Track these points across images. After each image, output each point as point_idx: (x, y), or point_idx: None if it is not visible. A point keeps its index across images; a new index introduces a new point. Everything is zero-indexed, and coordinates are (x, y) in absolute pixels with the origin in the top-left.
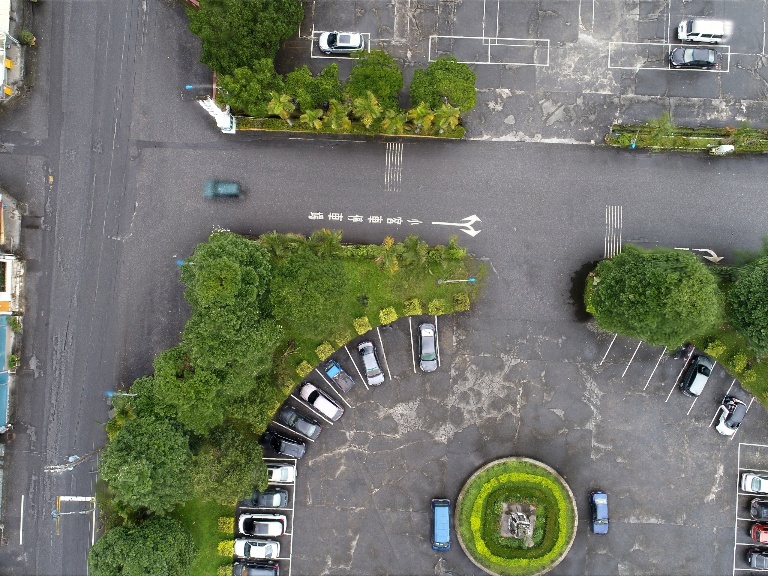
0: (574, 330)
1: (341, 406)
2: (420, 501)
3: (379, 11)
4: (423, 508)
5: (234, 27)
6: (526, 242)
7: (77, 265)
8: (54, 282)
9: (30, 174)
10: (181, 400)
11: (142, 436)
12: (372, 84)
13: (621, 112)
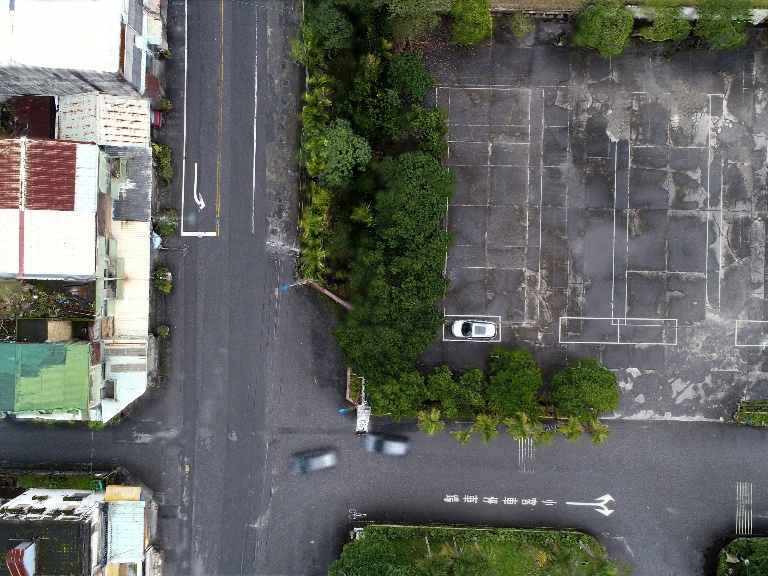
0: None
1: None
2: None
3: (509, 294)
4: None
5: (384, 347)
6: (659, 520)
7: (215, 553)
8: (192, 571)
9: (166, 464)
10: None
11: None
12: (515, 388)
13: (749, 389)
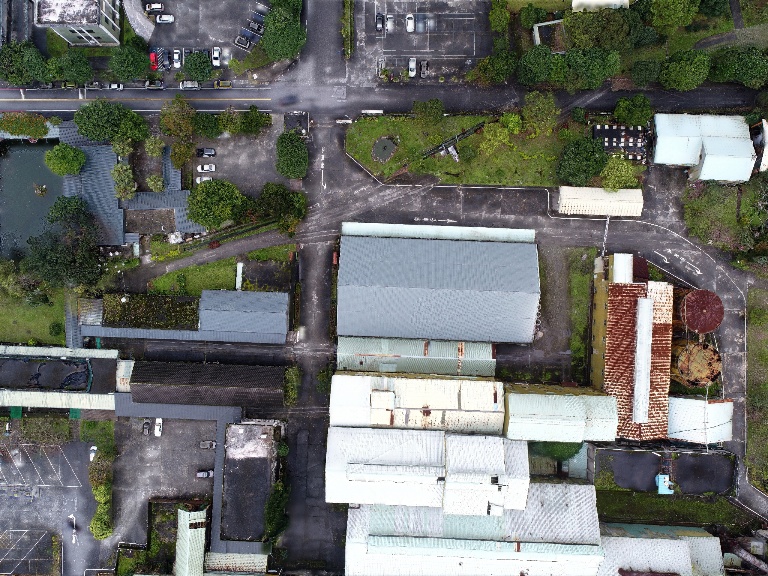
0: None
1: None
2: None
3: None
4: None
5: None
6: None
7: None
8: None
9: None
10: None
11: None
12: None
13: None
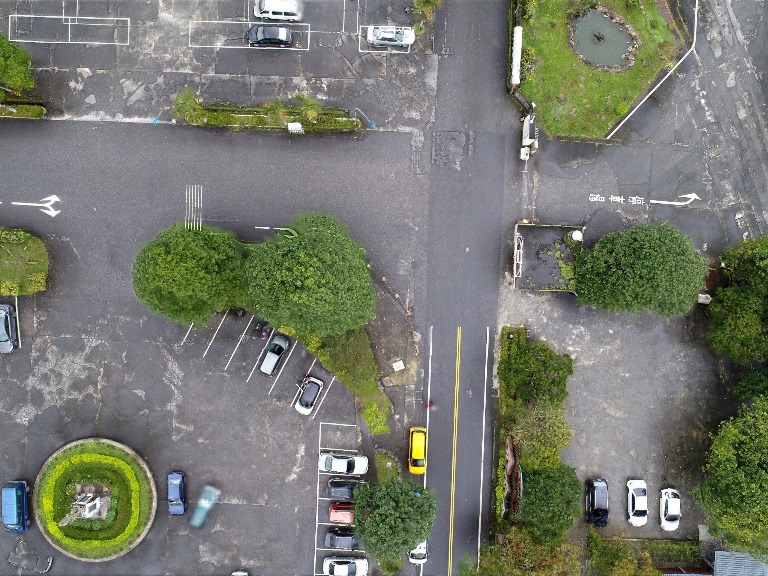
0: None
1: None
2: (1, 483)
3: None
4: None
5: None
6: (106, 222)
7: None
8: None
9: None
10: None
11: None
12: None
13: (202, 91)
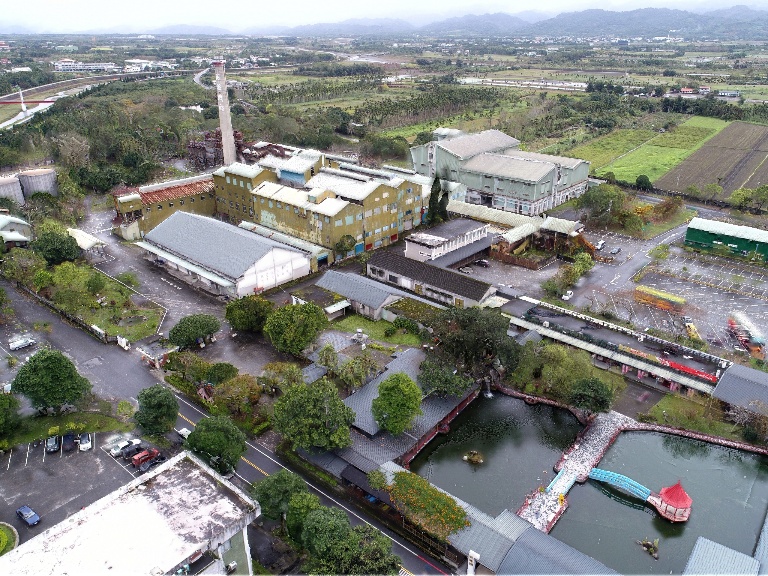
0: None
1: None
2: None
3: None
4: None
5: None
6: None
7: None
8: None
9: None
10: None
11: None
12: None
13: None
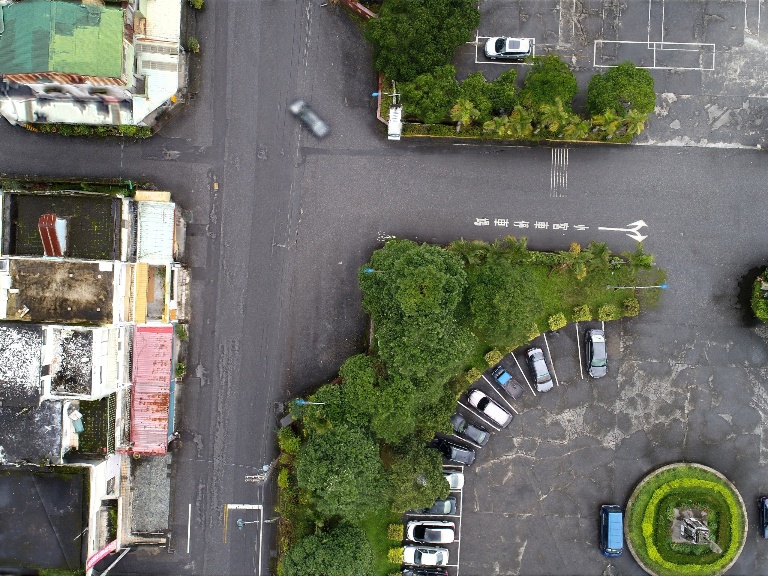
0: (741, 335)
1: (510, 412)
2: (588, 507)
3: (544, 16)
4: (591, 514)
5: (419, 34)
6: (693, 247)
7: (242, 273)
8: (220, 290)
9: (195, 182)
10: (380, 409)
11: (338, 445)
12: (550, 90)
13: None
